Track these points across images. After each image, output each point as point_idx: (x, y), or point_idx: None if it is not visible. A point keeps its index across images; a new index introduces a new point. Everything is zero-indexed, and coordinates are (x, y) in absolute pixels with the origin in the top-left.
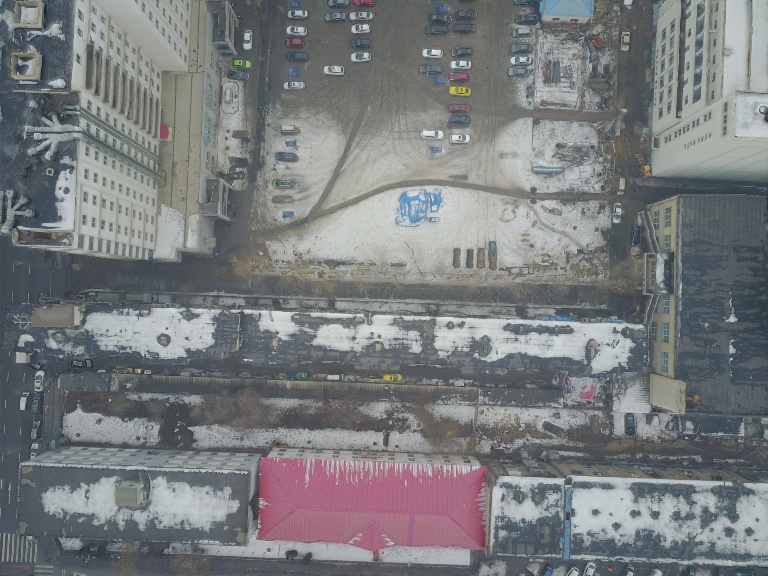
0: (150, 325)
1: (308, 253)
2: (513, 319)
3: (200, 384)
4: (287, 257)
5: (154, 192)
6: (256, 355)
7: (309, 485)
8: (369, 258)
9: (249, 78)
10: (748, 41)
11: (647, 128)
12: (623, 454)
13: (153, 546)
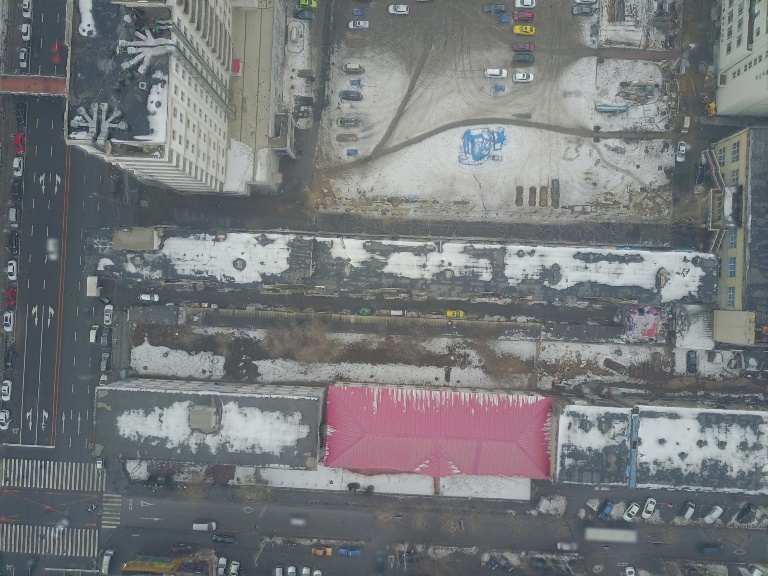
0: (226, 250)
1: (372, 191)
2: (583, 248)
3: (266, 318)
4: (351, 195)
5: (225, 125)
6: (328, 282)
7: (377, 412)
8: (432, 196)
9: (314, 17)
10: None
11: (712, 66)
12: (684, 392)
13: (218, 477)
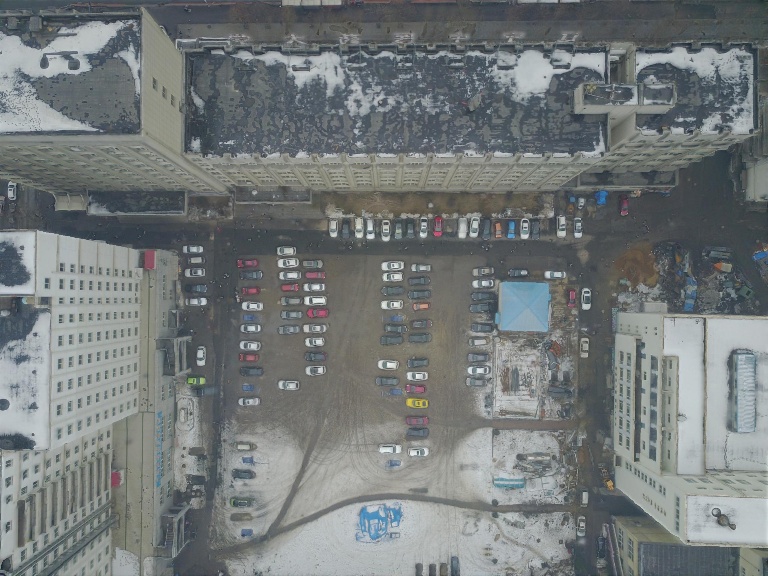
0: None
1: (268, 571)
2: None
3: None
4: (247, 575)
5: (108, 539)
6: None
7: None
8: (330, 575)
9: (204, 394)
10: (703, 406)
11: (609, 439)
12: None
13: None
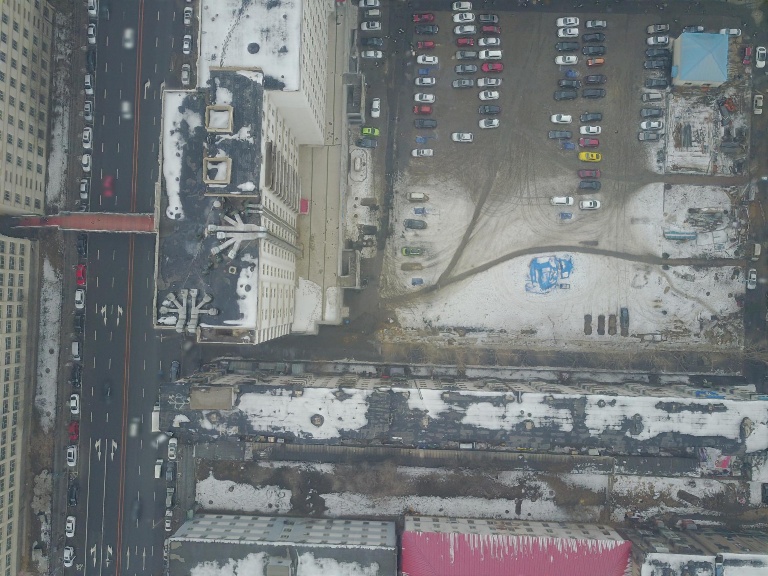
0: (303, 405)
1: (438, 320)
2: (665, 397)
3: (334, 453)
4: (417, 324)
5: (293, 265)
6: (406, 433)
7: (455, 561)
8: (499, 325)
9: (377, 146)
10: None
11: None
12: (760, 523)
13: None
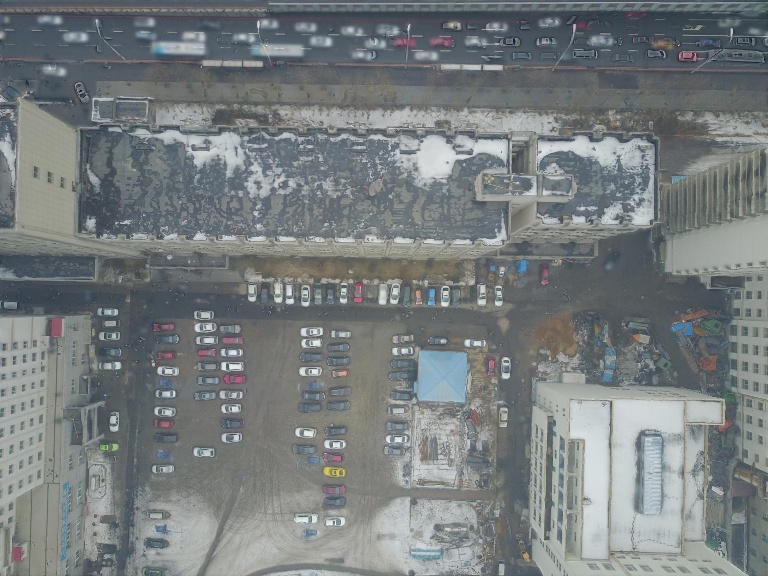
0: None
1: None
2: None
3: None
4: None
5: None
6: None
7: None
8: None
9: (116, 461)
10: (608, 490)
11: (526, 510)
12: None
13: None
